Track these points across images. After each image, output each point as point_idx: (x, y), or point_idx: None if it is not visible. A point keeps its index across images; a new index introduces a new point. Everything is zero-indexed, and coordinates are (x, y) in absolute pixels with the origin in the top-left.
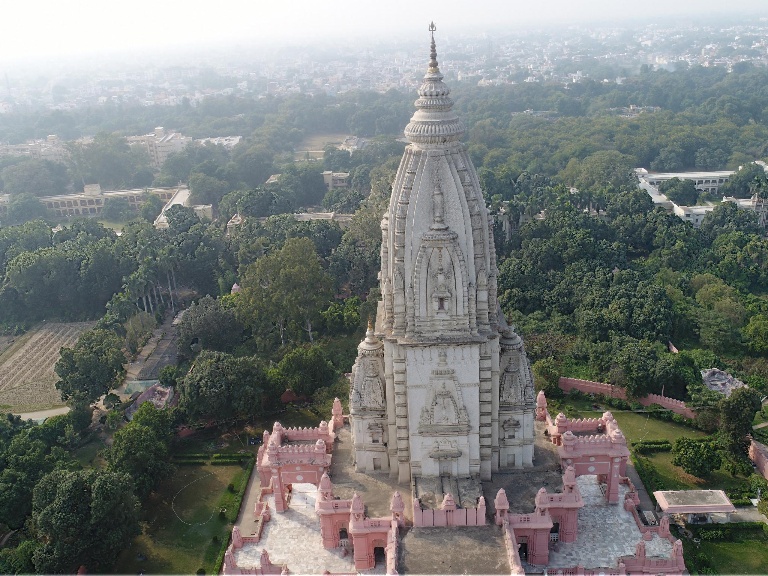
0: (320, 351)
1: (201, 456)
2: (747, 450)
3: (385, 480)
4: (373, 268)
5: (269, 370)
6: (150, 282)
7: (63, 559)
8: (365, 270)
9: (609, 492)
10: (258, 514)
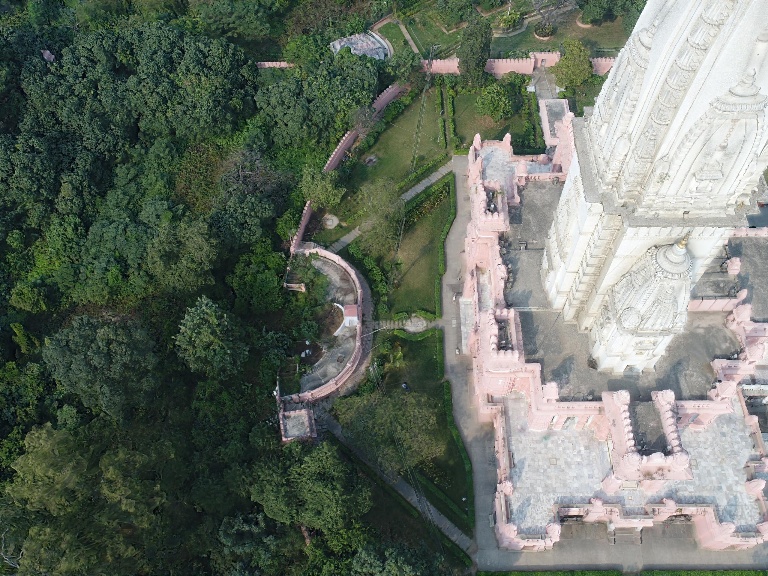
0: None
1: None
2: None
3: None
4: None
5: (338, 549)
6: None
7: None
8: None
9: None
10: None
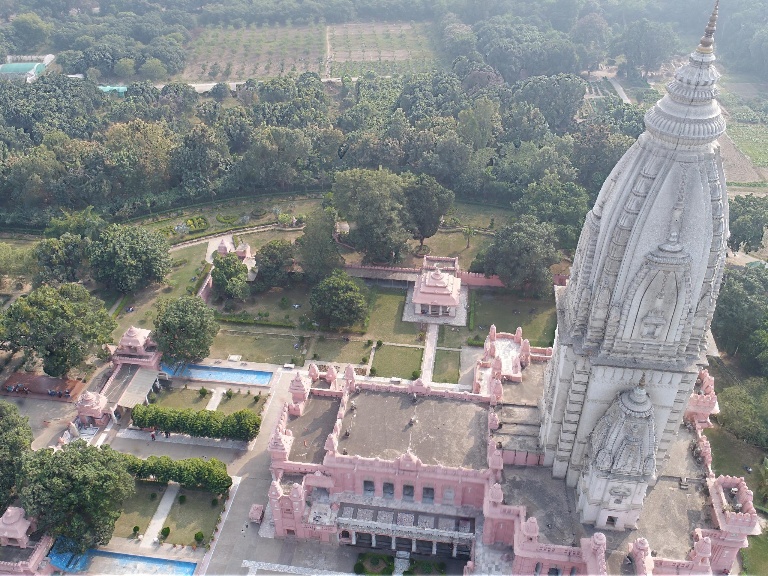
0: None
1: None
2: None
3: None
4: None
5: None
6: None
7: None
8: None
9: None
10: None
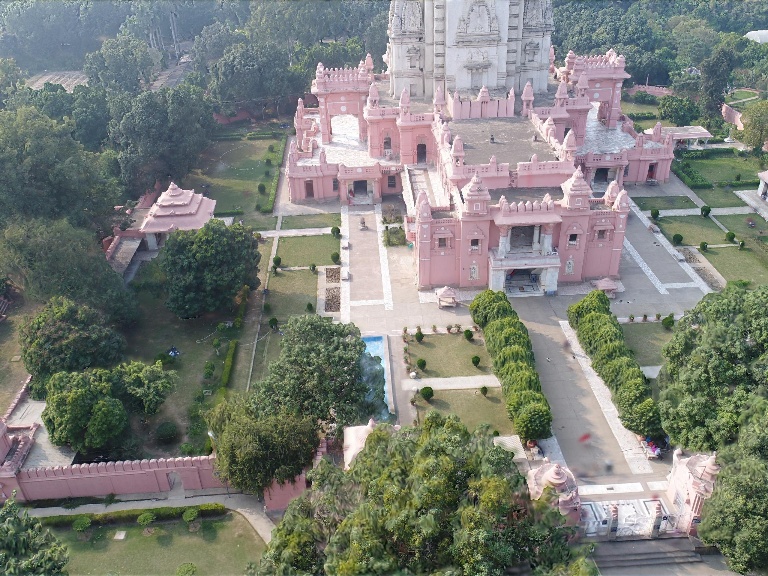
0: (339, 48)
1: (237, 134)
2: (721, 108)
3: (421, 102)
4: (370, 14)
5: None
6: (156, 17)
7: (146, 158)
8: (361, 19)
9: (610, 118)
10: (305, 148)
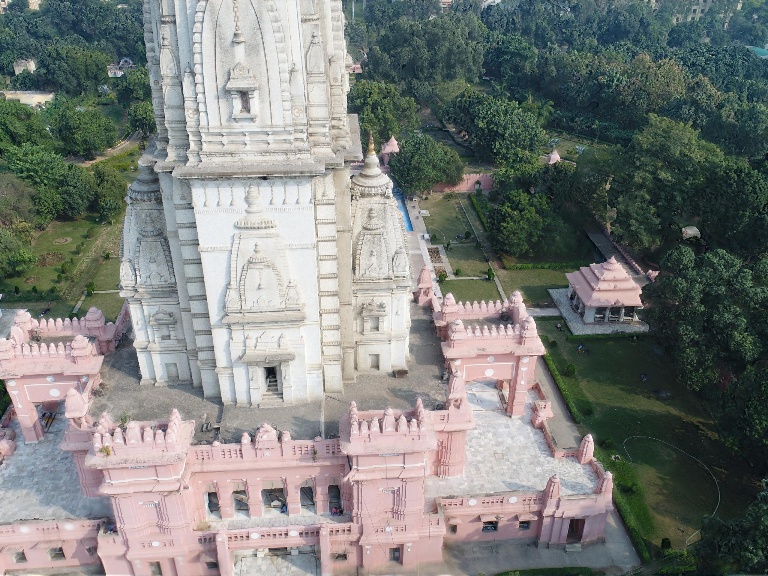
0: None
1: None
2: None
3: None
4: None
5: None
6: None
7: None
8: None
9: None
10: None
